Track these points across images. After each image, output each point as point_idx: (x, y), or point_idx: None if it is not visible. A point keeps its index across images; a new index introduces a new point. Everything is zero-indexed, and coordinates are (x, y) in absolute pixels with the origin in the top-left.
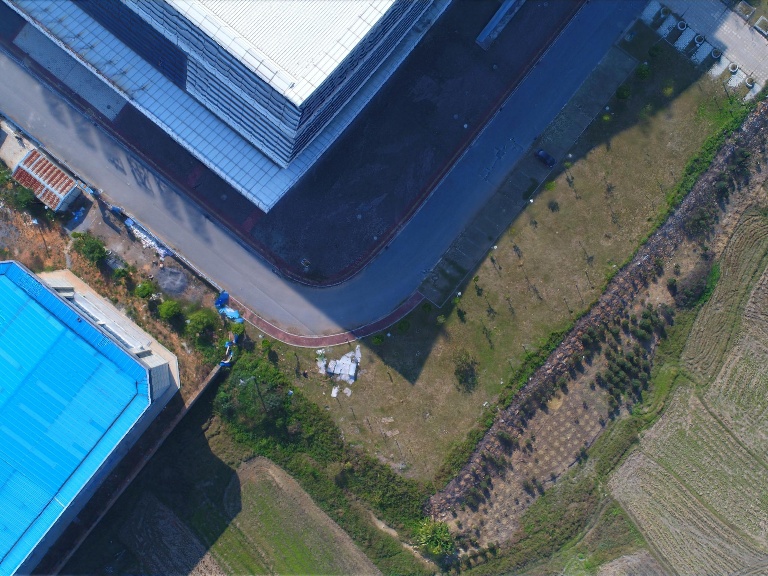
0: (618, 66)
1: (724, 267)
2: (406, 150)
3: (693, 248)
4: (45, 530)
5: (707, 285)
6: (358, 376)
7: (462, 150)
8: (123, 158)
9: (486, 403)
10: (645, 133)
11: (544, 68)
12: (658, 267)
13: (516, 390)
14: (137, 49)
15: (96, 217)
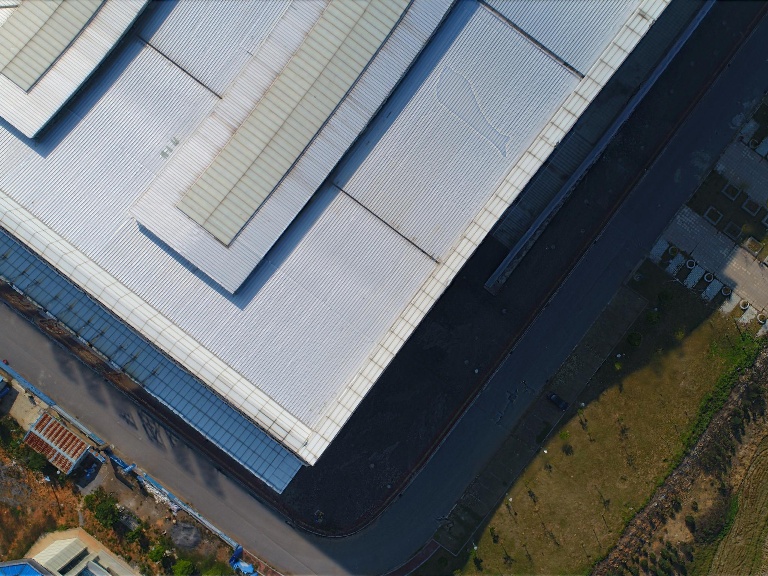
0: (628, 306)
1: (742, 499)
2: (417, 398)
3: (710, 482)
4: None
5: (726, 520)
6: None
7: (474, 395)
8: (134, 413)
9: None
10: (658, 373)
11: (553, 310)
12: (675, 502)
13: None
14: None
15: (108, 473)
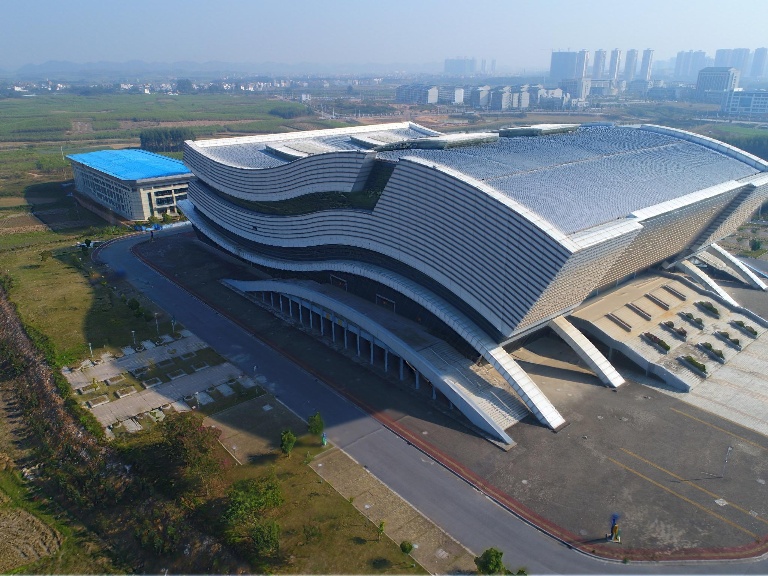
0: (158, 319)
1: None
2: None
3: None
4: (103, 171)
5: None
6: (78, 247)
7: None
8: None
9: (8, 270)
10: None
11: None
12: None
13: (0, 276)
14: None
15: None
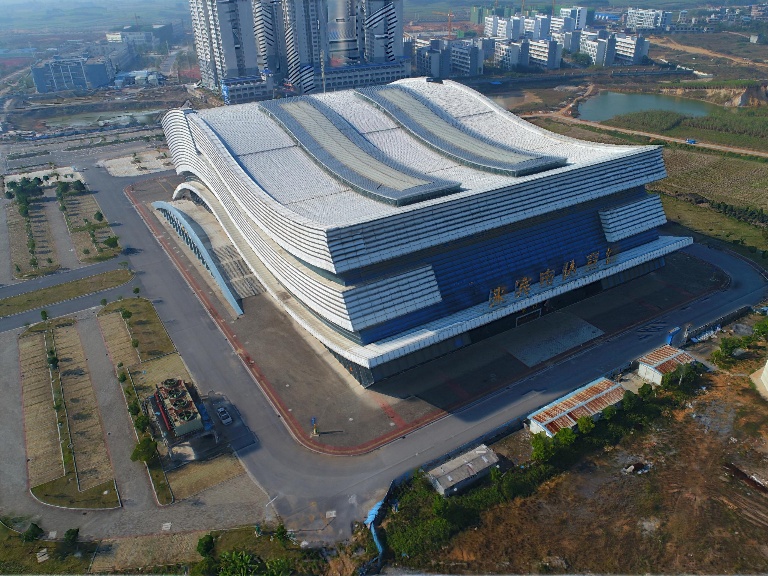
0: None
1: None
2: None
3: None
4: None
5: None
6: None
7: None
8: None
9: None
10: None
11: None
12: None
13: None
14: (576, 265)
15: (693, 355)
